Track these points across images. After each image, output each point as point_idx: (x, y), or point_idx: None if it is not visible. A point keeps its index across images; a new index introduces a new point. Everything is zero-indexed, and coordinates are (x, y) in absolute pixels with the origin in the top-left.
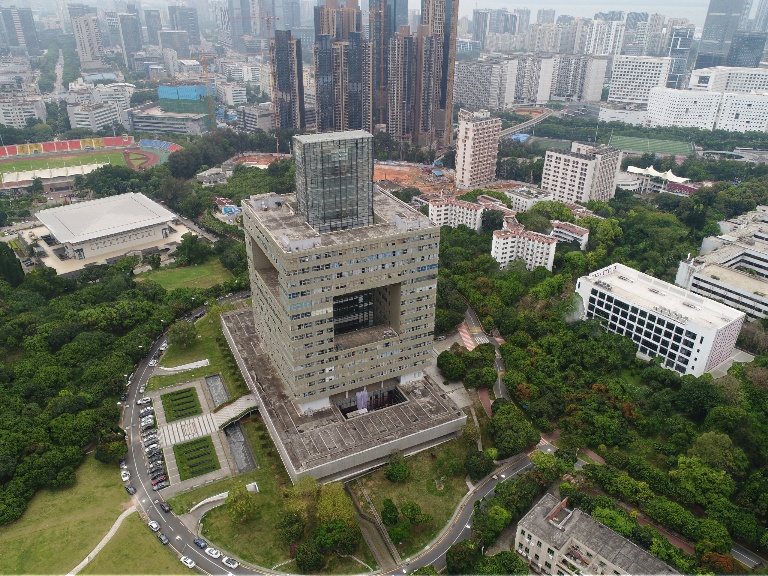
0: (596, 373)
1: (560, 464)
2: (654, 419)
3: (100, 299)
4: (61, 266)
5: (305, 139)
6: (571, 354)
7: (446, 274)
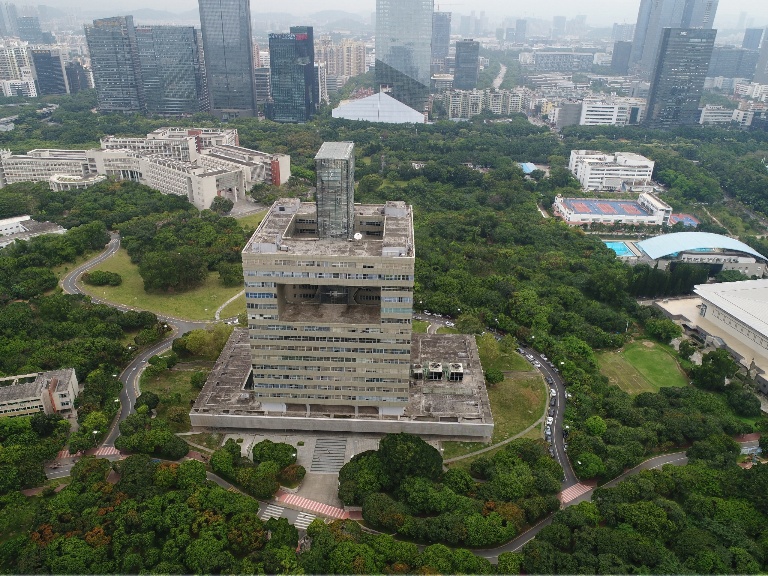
0: (119, 573)
1: (79, 432)
2: (7, 546)
3: (570, 307)
4: (682, 306)
5: (336, 143)
6: (163, 552)
7: (500, 559)
